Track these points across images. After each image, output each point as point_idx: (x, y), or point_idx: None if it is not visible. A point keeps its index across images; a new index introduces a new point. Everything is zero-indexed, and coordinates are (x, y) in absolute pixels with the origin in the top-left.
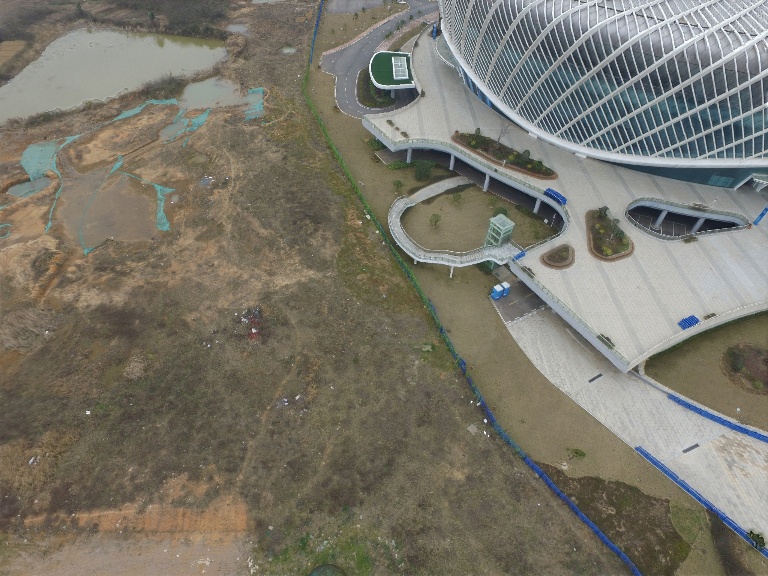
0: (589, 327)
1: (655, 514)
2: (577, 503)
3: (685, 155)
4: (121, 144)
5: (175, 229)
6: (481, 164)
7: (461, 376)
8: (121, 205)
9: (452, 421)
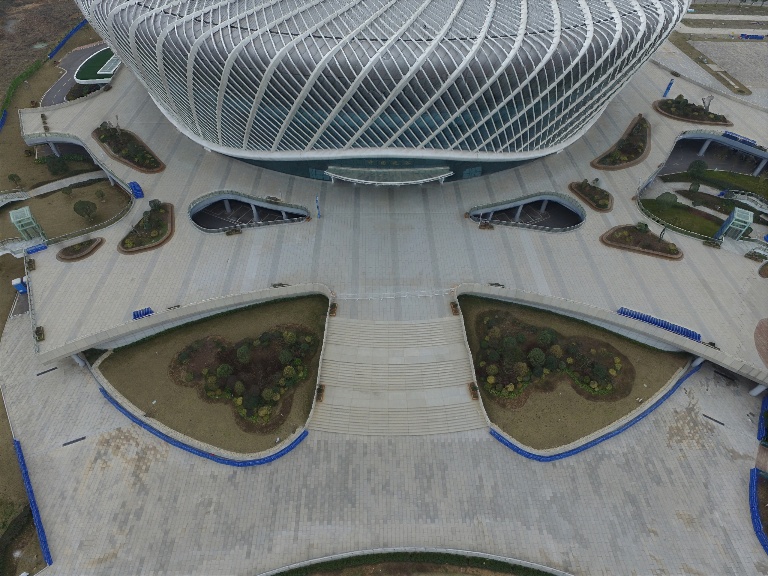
0: (38, 320)
1: None
2: None
3: (261, 148)
4: None
5: None
6: (94, 158)
7: None
8: None
9: None
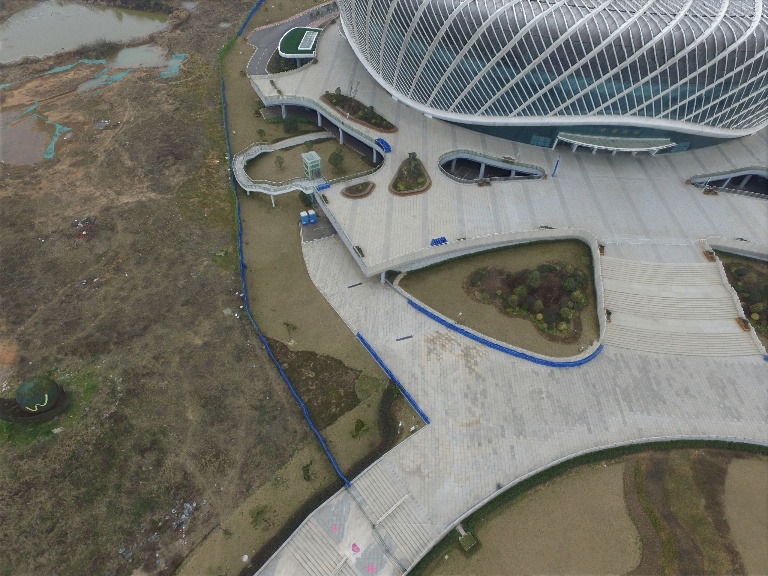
0: (351, 241)
1: (345, 379)
2: (287, 368)
3: (499, 113)
4: (42, 92)
5: (57, 157)
6: (333, 118)
7: (238, 275)
8: (21, 138)
9: (213, 305)
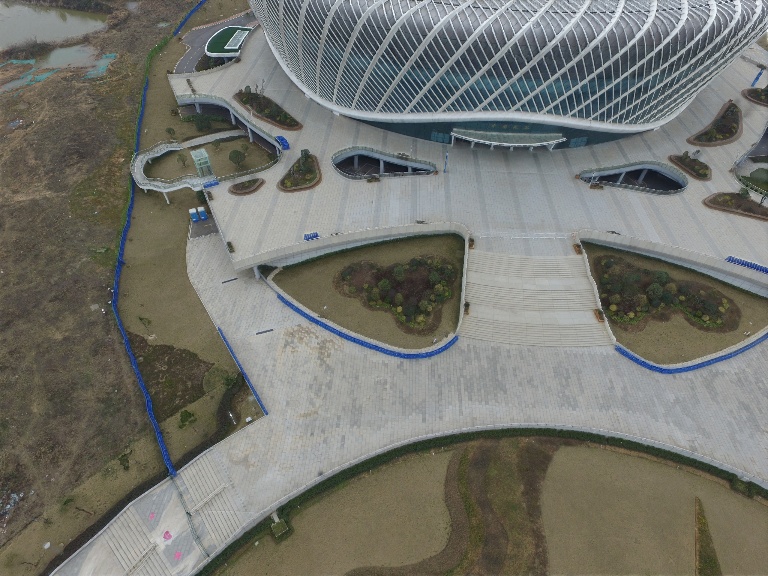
0: (226, 237)
1: (195, 372)
2: (141, 361)
3: (395, 110)
4: None
5: None
6: (240, 116)
7: (114, 271)
8: None
9: (81, 300)
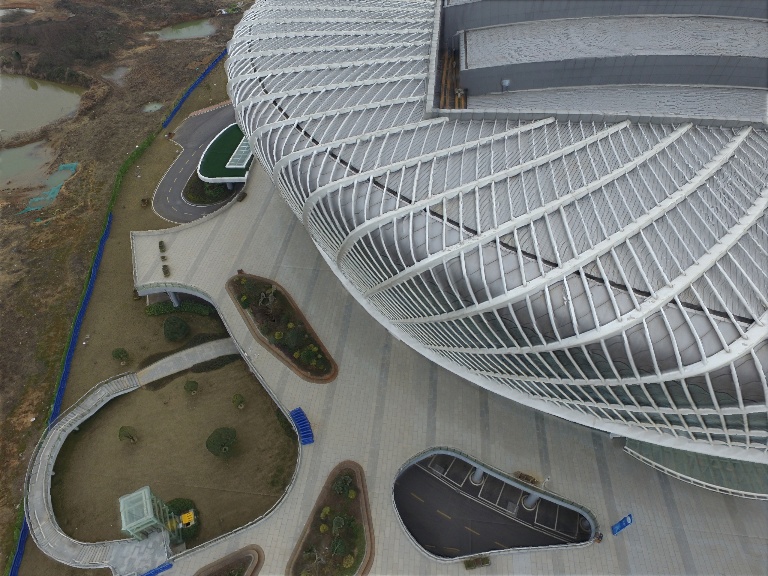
0: None
1: None
2: None
3: (513, 387)
4: None
5: None
6: None
7: None
8: None
9: None
